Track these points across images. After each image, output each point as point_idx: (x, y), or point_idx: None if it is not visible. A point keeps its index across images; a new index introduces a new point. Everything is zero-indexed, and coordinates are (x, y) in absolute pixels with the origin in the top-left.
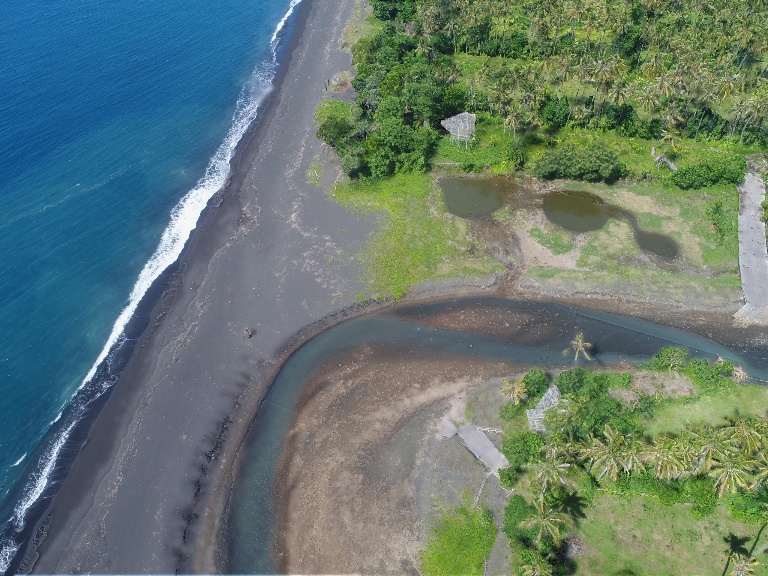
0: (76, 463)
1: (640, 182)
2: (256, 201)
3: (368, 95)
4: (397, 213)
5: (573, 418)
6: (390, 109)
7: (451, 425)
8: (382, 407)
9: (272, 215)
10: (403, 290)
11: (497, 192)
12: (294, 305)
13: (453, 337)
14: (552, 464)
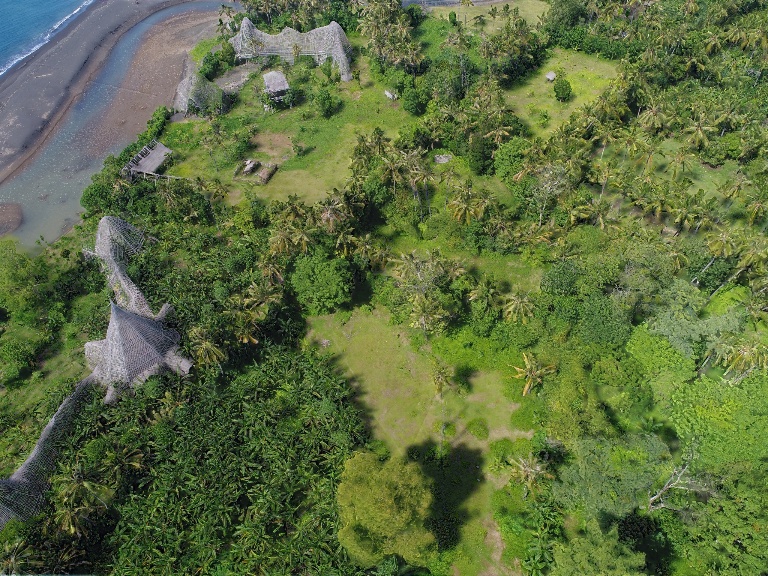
0: None
1: None
2: None
3: None
4: None
5: None
6: None
7: None
8: (193, 21)
9: None
10: None
11: None
12: None
13: (237, 4)
14: None
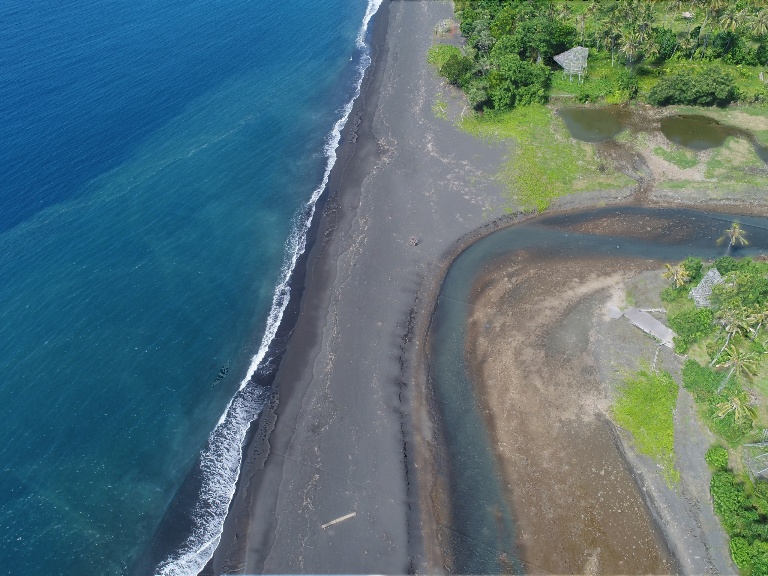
0: (287, 348)
1: (752, 104)
2: (390, 135)
3: (479, 37)
4: (525, 140)
5: (742, 289)
6: (508, 46)
7: (616, 309)
8: (548, 298)
9: (409, 146)
10: (546, 203)
11: (614, 119)
12: (449, 218)
13: (600, 240)
14: (742, 316)
